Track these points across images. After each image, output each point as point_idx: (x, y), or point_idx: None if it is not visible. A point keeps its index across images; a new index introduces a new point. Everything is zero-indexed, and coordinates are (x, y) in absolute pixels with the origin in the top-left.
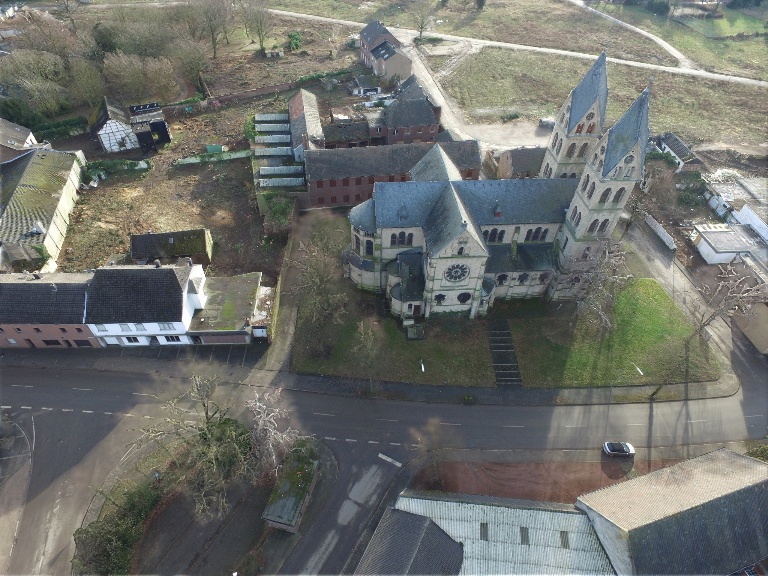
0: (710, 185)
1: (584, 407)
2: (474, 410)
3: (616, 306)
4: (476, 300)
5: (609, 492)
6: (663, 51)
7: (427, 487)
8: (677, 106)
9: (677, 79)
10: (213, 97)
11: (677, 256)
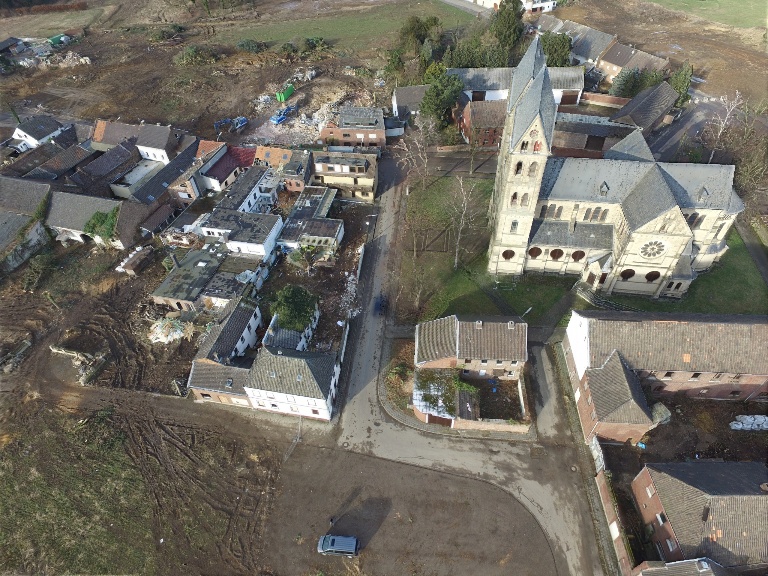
0: None
1: None
2: None
3: None
4: None
5: None
6: None
7: None
8: None
9: None
10: None
11: (365, 242)
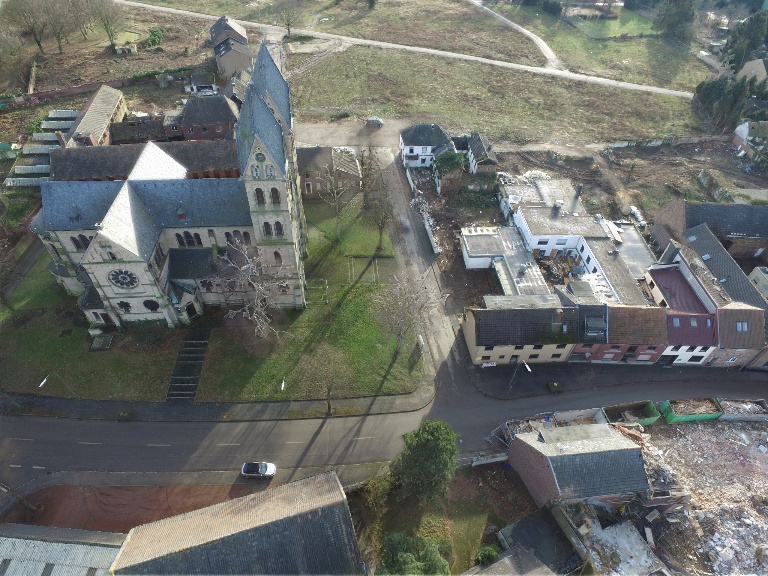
0: (504, 187)
1: (250, 423)
2: (126, 427)
3: (339, 314)
4: (163, 308)
5: (168, 522)
6: (536, 51)
7: (21, 515)
8: (521, 106)
9: (536, 79)
10: (30, 93)
11: (438, 260)
